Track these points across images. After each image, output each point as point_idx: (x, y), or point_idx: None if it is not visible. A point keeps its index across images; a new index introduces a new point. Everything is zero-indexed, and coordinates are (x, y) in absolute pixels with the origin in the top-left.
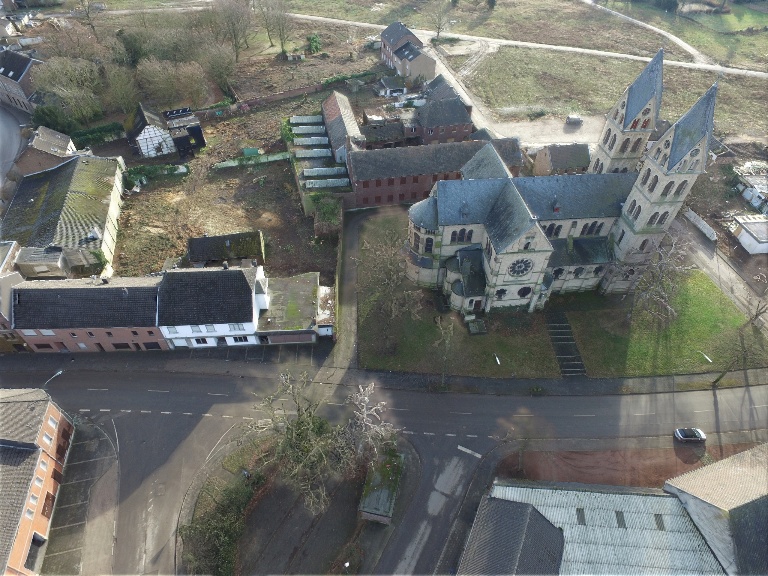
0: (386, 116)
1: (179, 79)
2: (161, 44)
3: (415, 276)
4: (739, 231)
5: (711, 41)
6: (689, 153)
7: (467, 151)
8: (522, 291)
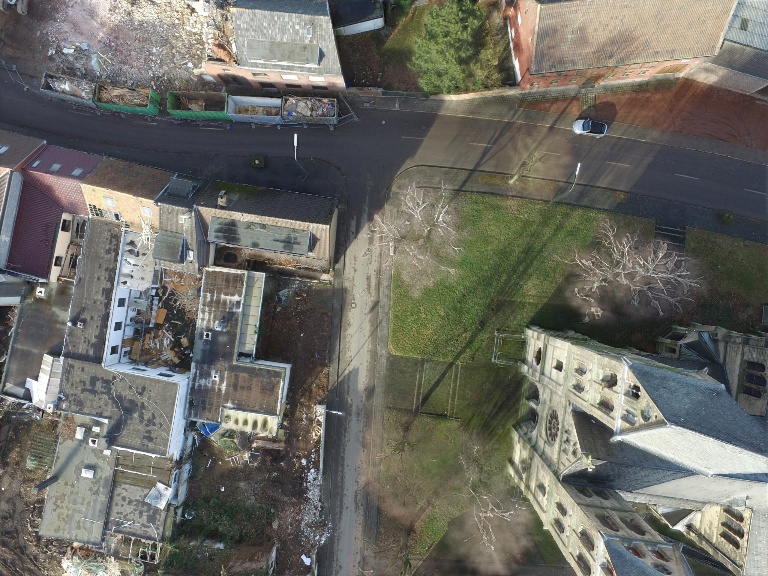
0: None
1: None
2: None
3: None
4: None
5: None
6: None
7: None
8: None
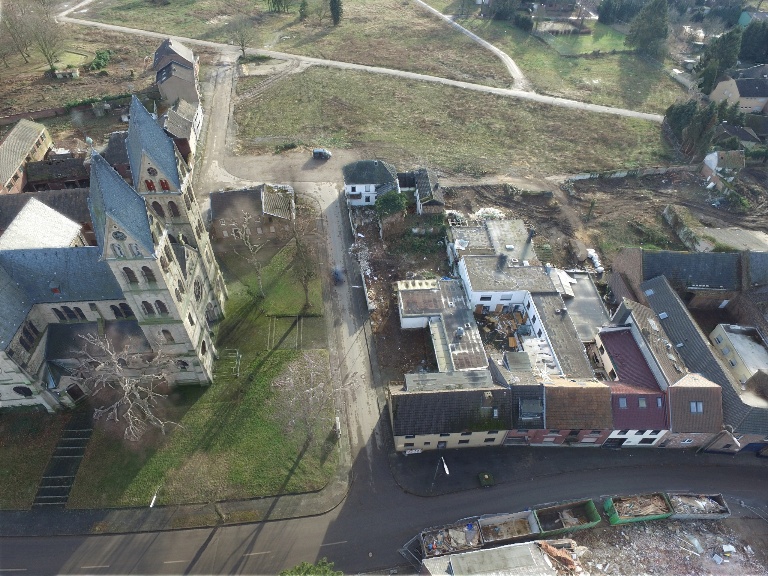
0: (78, 149)
1: None
2: None
3: None
4: (398, 299)
5: (546, 64)
6: (111, 236)
7: None
8: (20, 390)
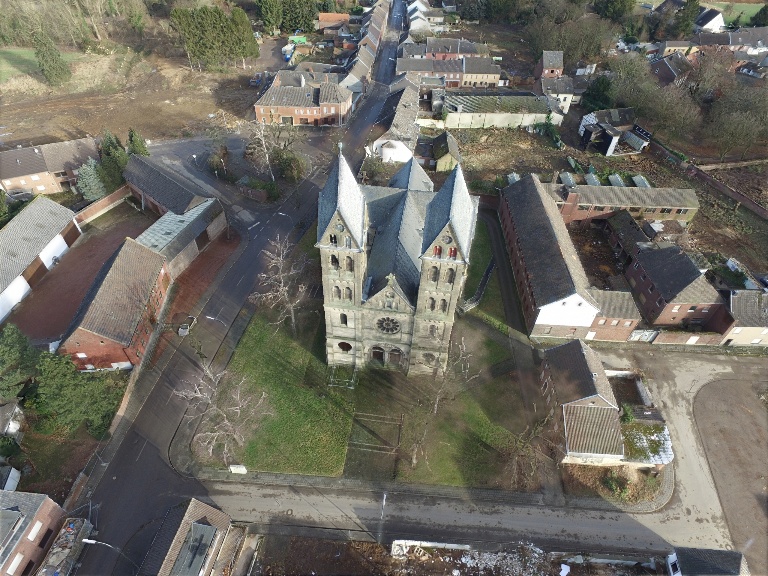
0: (669, 236)
1: (668, 110)
2: (733, 94)
3: None
4: None
5: None
6: None
7: (547, 250)
8: None
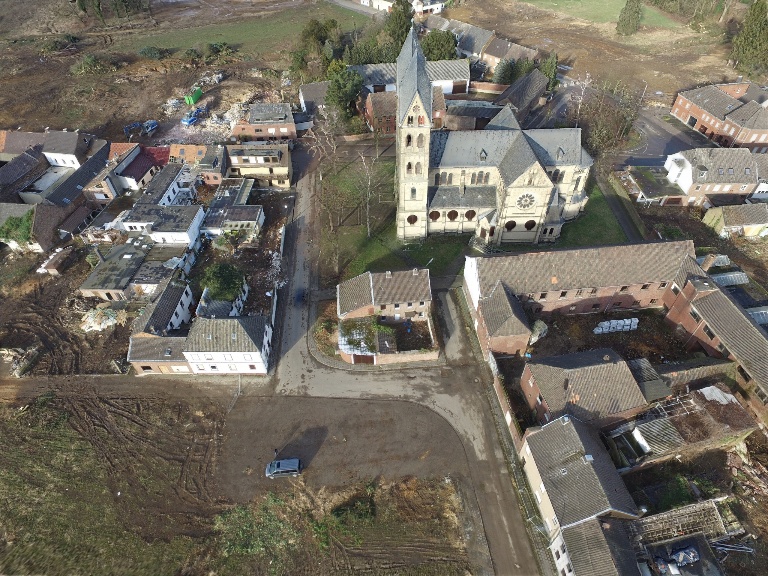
0: (700, 407)
1: None
2: None
3: None
4: None
5: None
6: None
7: None
8: None
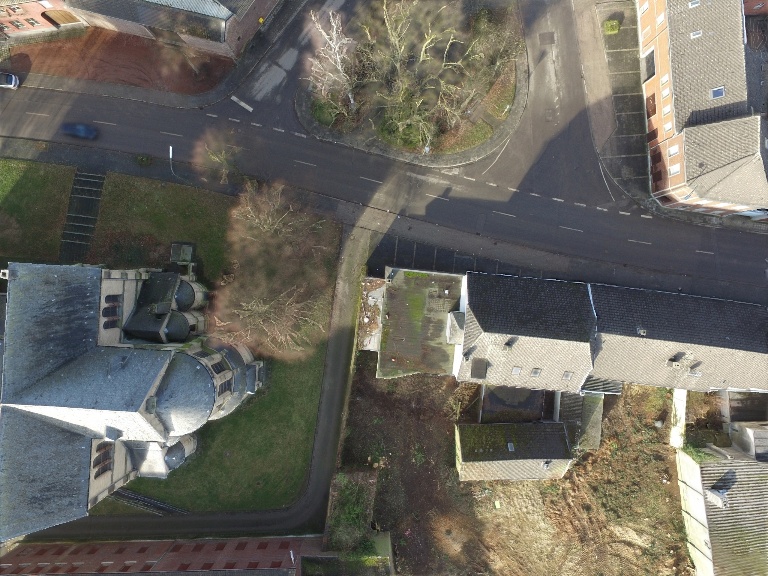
0: None
1: None
2: None
3: (240, 346)
4: None
5: None
6: None
7: None
8: None
